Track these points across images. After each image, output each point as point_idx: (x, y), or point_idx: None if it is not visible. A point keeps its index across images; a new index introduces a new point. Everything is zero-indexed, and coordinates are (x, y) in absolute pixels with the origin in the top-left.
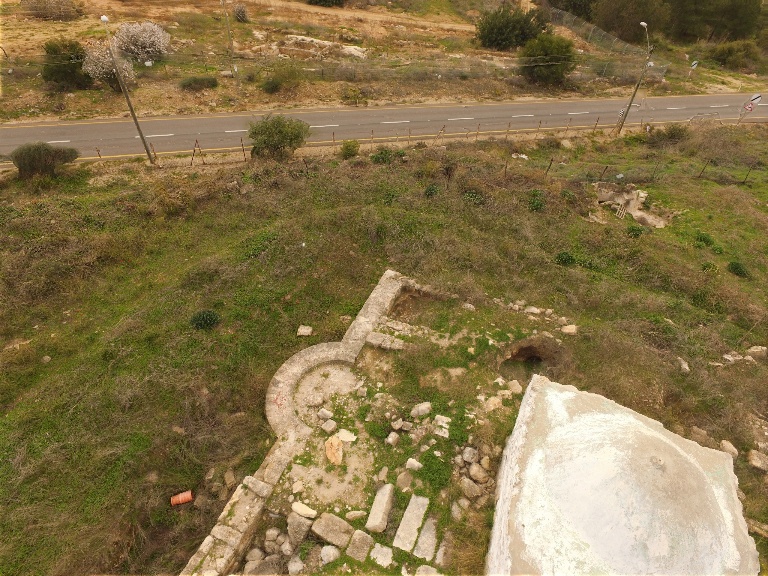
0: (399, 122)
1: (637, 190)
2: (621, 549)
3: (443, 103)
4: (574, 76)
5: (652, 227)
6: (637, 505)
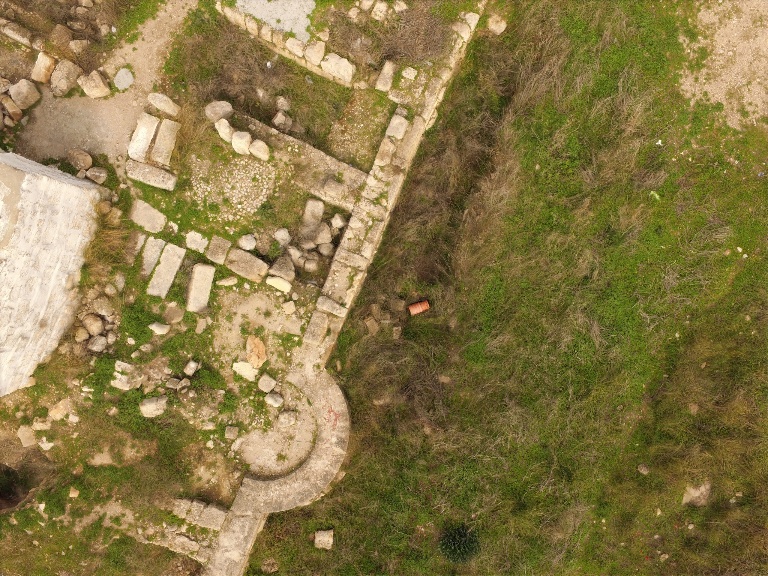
0: None
1: None
2: None
3: None
4: None
5: None
6: None
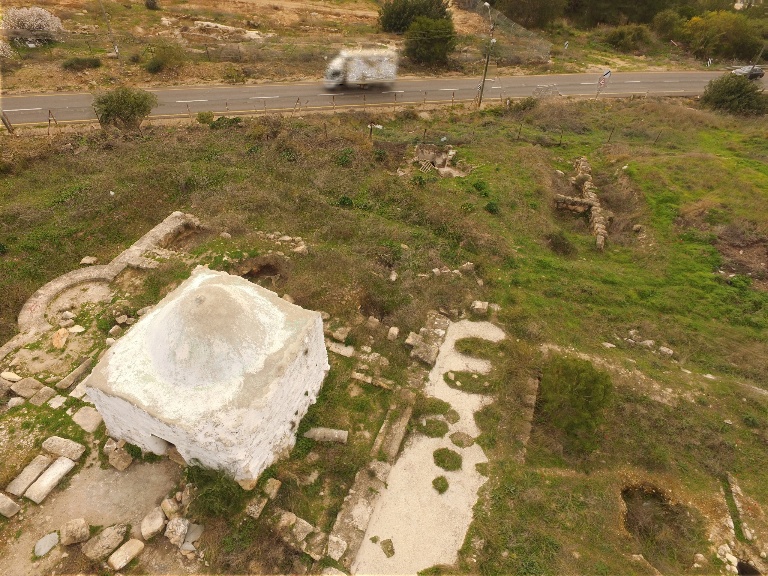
0: (268, 97)
1: (449, 150)
2: (163, 358)
3: (321, 81)
4: (461, 57)
5: (444, 178)
6: (175, 326)
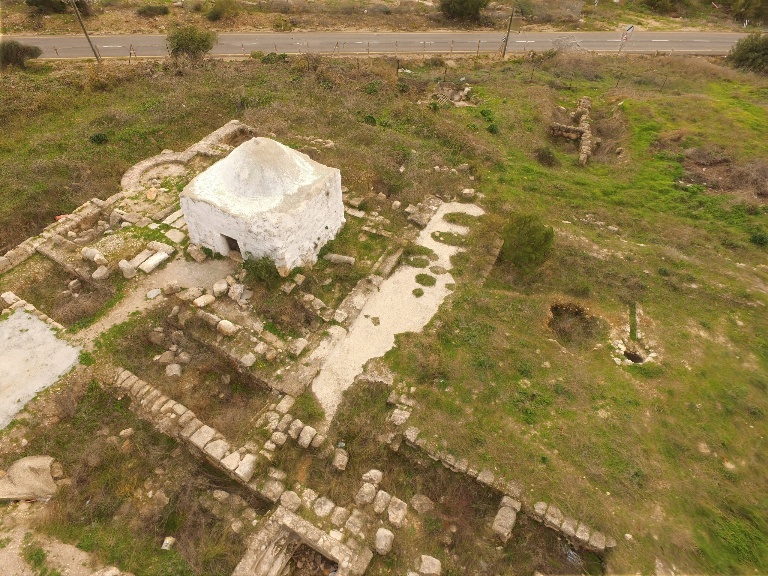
0: None
1: (466, 87)
2: (231, 180)
3: (359, 31)
4: (493, 14)
5: None
6: (240, 158)
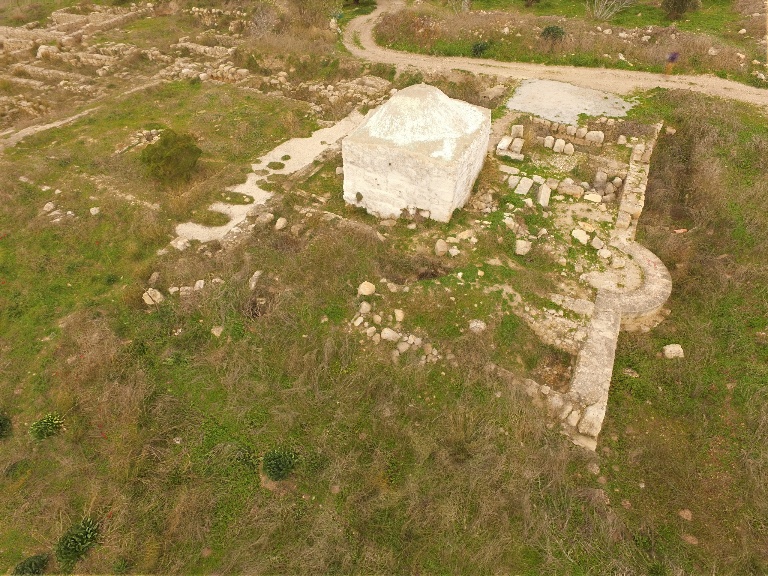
0: None
1: None
2: None
3: None
4: None
5: None
6: None
